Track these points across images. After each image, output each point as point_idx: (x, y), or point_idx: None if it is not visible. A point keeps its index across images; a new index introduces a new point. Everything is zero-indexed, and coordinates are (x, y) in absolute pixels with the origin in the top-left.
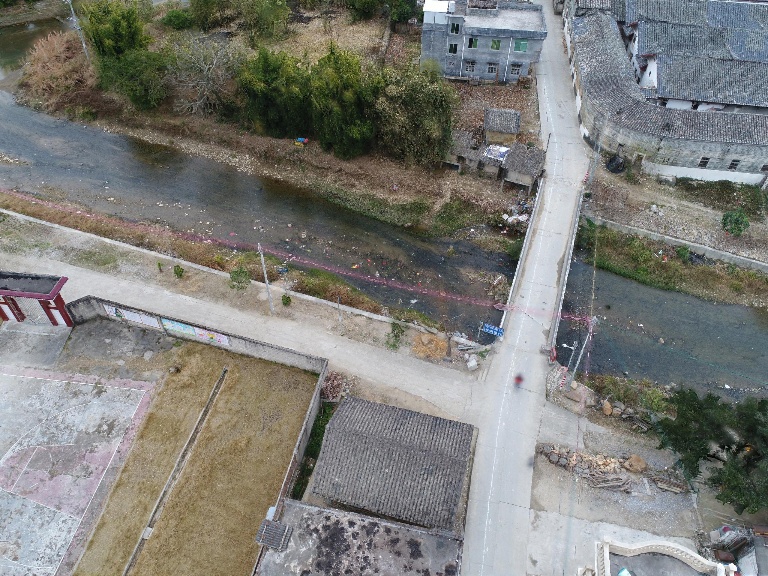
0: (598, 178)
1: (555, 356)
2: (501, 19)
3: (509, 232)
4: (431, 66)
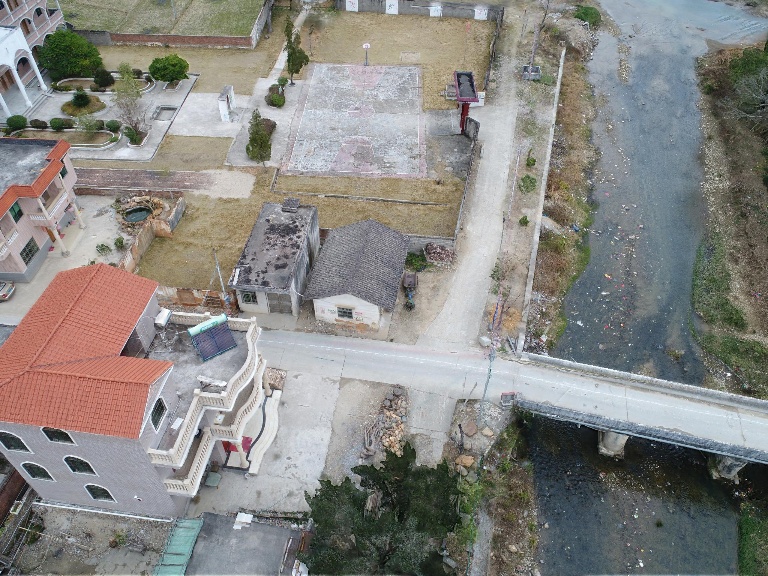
0: None
1: (503, 394)
2: None
3: None
4: None
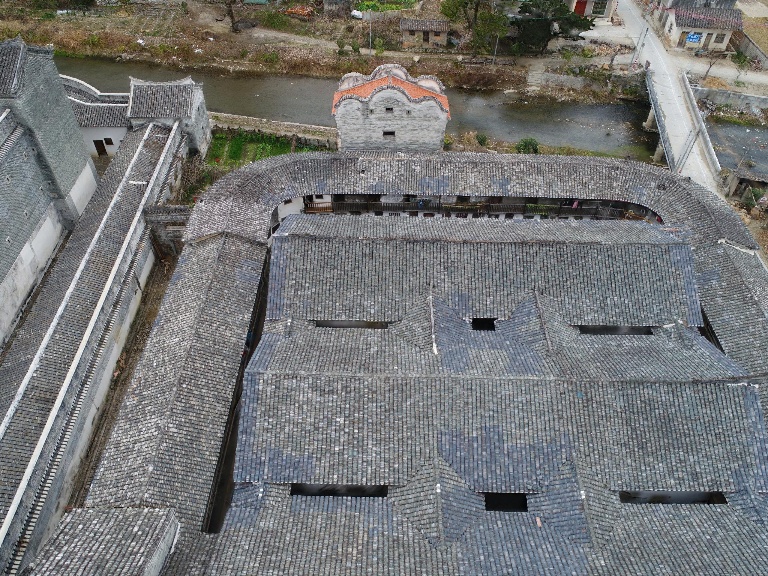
0: None
1: None
2: None
3: None
4: None
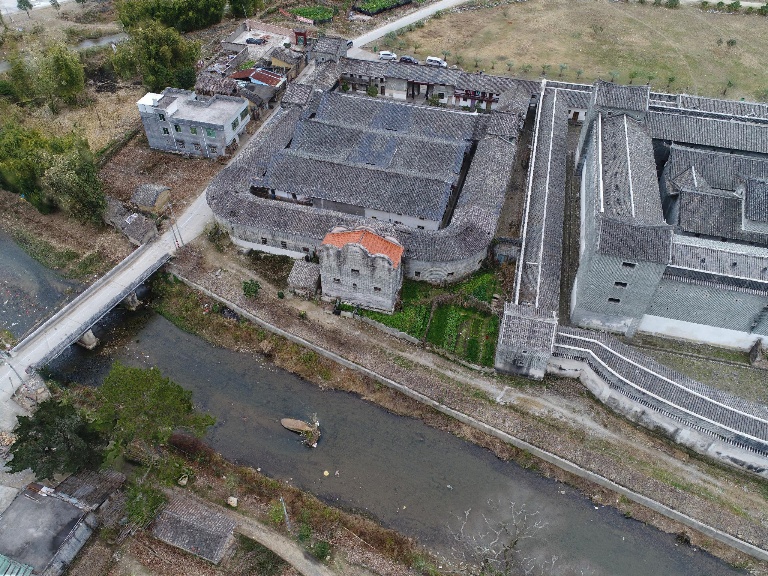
0: (196, 245)
1: None
2: (209, 109)
3: None
4: (155, 142)
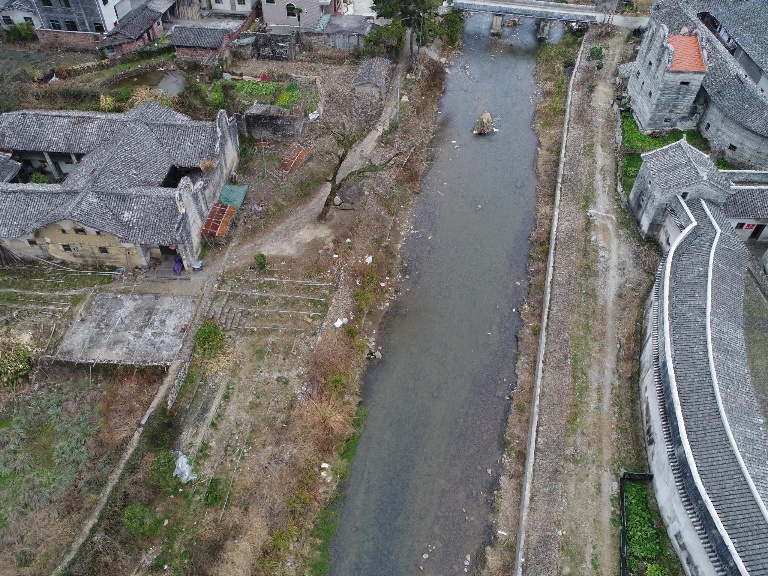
0: (620, 30)
1: None
2: None
3: (561, 25)
4: None
